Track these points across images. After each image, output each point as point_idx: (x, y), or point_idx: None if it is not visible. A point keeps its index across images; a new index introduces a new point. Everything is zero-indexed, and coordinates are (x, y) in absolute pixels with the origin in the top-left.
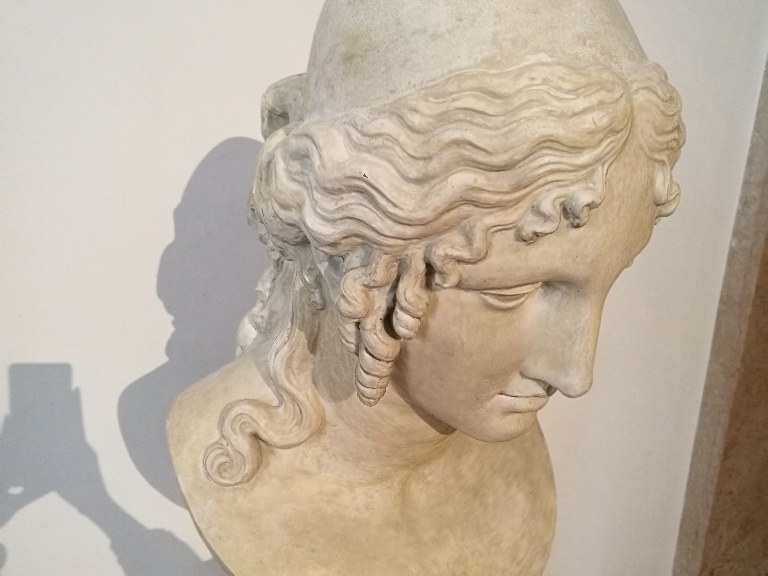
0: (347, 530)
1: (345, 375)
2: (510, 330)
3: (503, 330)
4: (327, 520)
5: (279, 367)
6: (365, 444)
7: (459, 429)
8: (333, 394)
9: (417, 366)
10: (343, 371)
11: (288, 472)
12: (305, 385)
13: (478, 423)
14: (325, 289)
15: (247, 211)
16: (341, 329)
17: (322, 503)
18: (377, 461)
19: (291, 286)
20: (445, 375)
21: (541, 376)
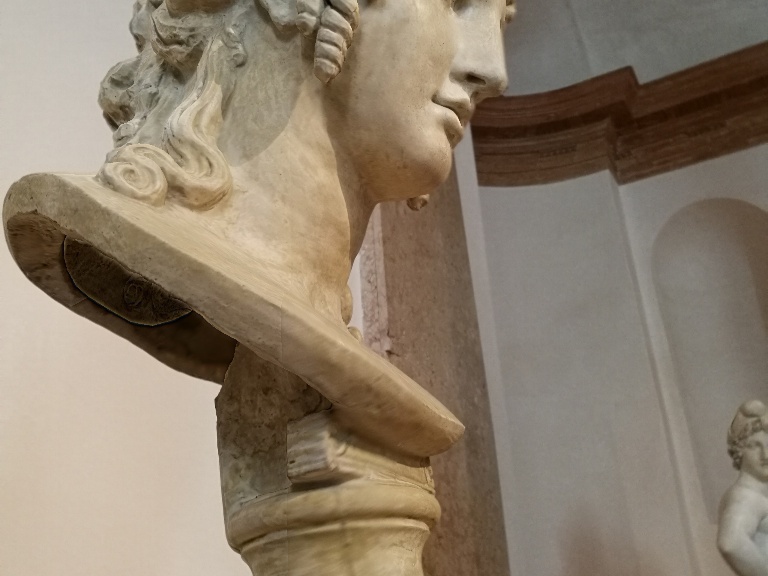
0: (275, 283)
1: (268, 119)
2: (444, 21)
3: (441, 16)
4: (250, 268)
5: (187, 121)
6: (280, 212)
7: (397, 145)
8: (248, 150)
9: (369, 49)
10: (266, 115)
11: (194, 224)
12: (213, 145)
13: (418, 128)
14: (248, 45)
15: (104, 85)
16: (304, 1)
17: (239, 258)
18: (289, 241)
19: (201, 60)
20: (398, 49)
21: (470, 67)
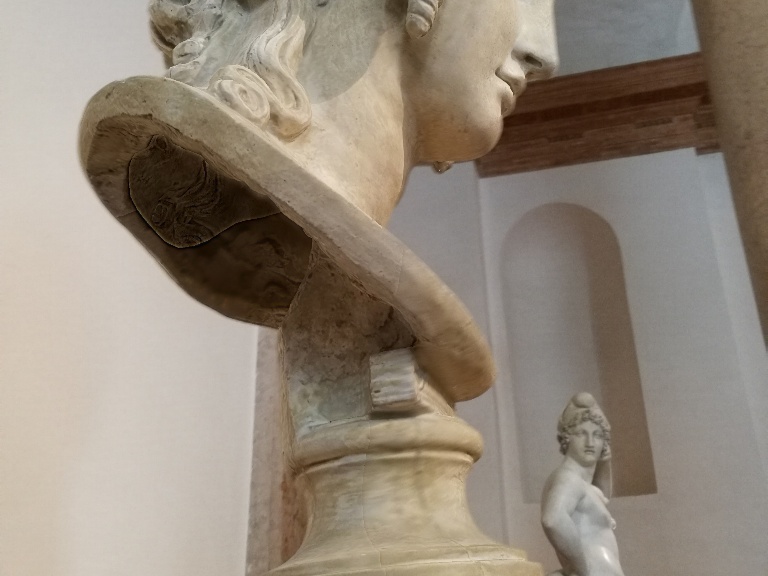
0: None
1: (348, 63)
2: None
3: None
4: None
5: (273, 50)
6: (352, 155)
7: (463, 109)
8: (327, 90)
9: (452, 14)
10: (346, 59)
11: None
12: None
13: (483, 97)
14: None
15: None
16: None
17: None
18: (358, 184)
19: None
20: (478, 20)
21: (531, 48)
